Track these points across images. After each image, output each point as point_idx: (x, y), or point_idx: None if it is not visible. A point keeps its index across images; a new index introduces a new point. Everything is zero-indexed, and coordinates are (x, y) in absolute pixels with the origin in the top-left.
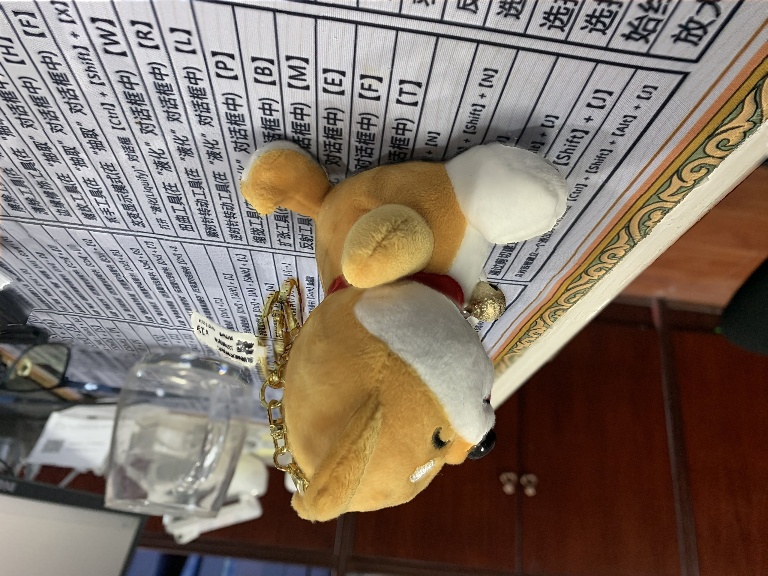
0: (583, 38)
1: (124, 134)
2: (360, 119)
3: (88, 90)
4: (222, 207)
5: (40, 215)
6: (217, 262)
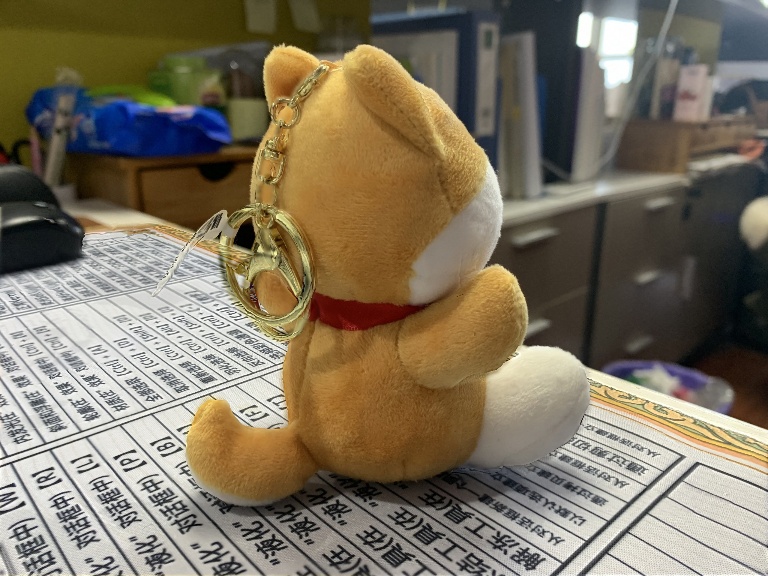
0: None
1: None
2: None
3: None
4: None
5: None
6: None
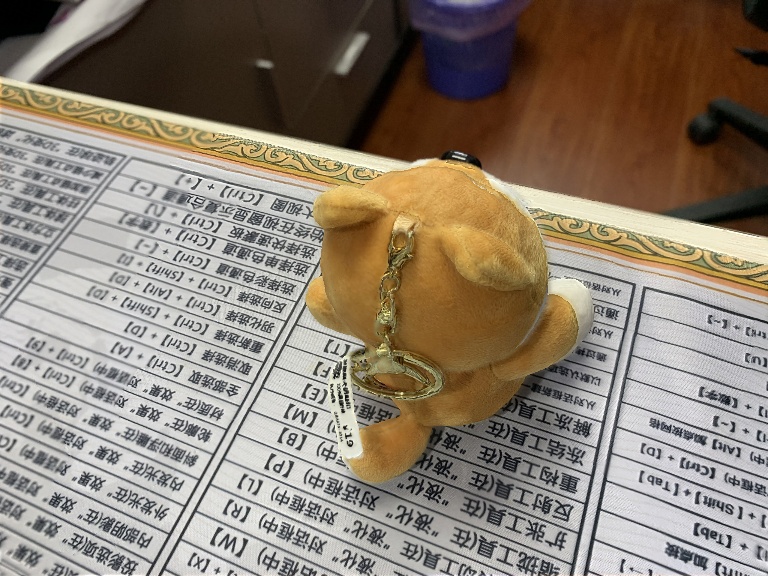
0: (317, 258)
1: None
2: (355, 387)
3: None
4: None
5: None
6: None
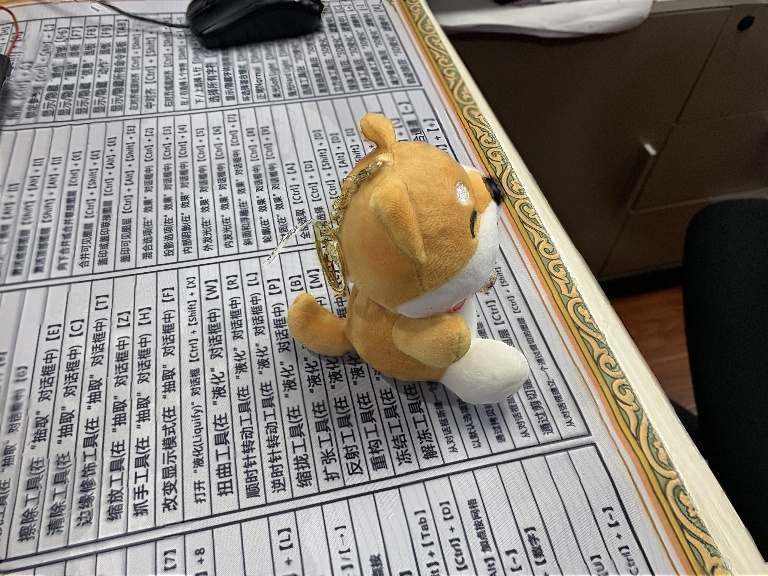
0: None
1: (197, 365)
2: None
3: (184, 332)
4: (266, 432)
5: (49, 540)
6: (253, 575)
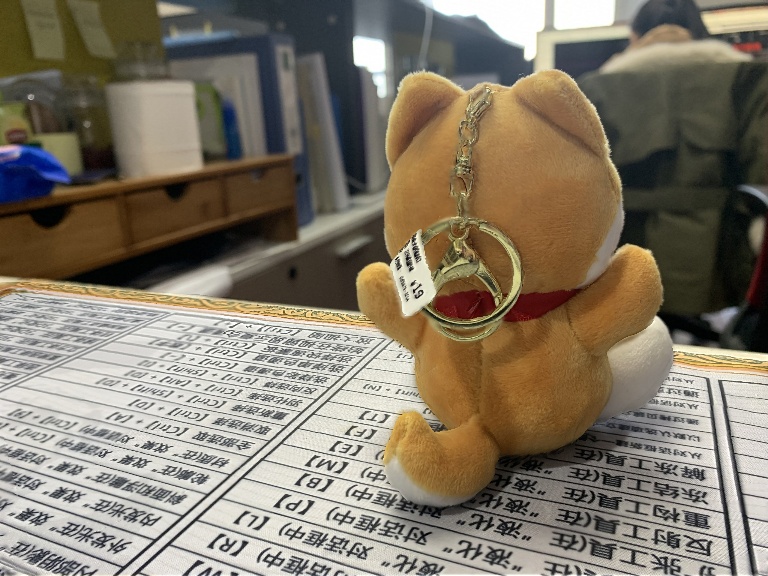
0: None
1: None
2: None
3: None
4: None
5: None
6: None
